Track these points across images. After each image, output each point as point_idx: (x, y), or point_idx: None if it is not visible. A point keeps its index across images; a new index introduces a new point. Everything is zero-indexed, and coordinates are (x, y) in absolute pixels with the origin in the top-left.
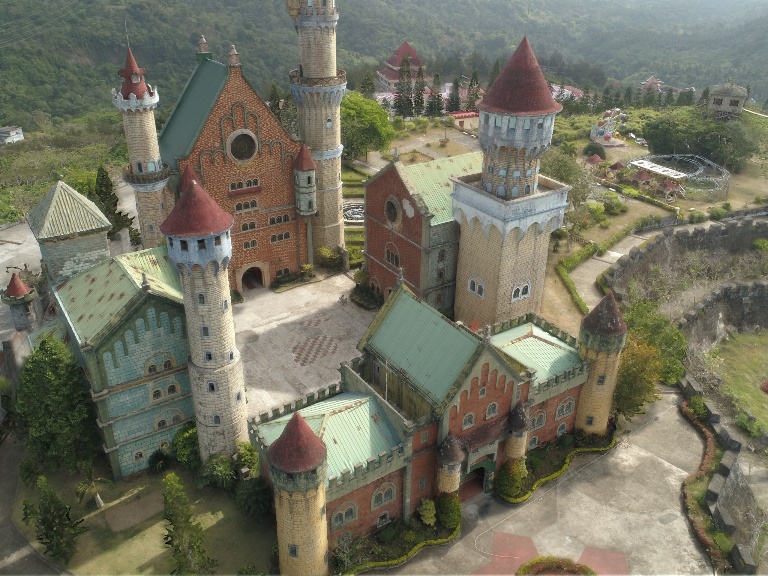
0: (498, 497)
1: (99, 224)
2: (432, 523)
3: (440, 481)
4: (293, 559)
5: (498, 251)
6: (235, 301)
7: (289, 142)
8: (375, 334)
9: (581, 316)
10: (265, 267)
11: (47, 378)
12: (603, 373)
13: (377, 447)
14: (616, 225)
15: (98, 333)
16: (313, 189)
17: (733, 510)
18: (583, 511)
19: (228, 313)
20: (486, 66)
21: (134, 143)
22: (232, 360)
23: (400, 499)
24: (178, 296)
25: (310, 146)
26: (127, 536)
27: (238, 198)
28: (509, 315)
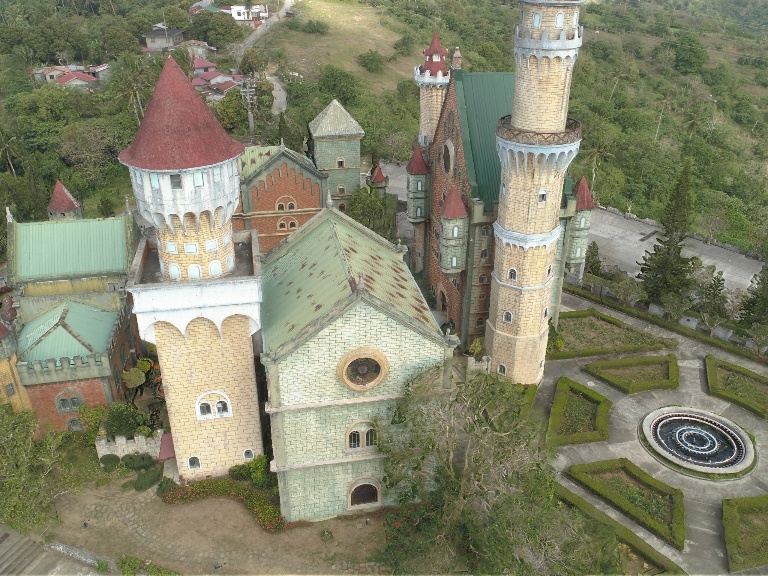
0: None
1: None
2: None
3: None
4: None
5: None
6: None
7: None
8: None
9: (194, 575)
10: None
11: None
12: None
13: None
14: None
15: None
16: None
17: None
18: None
19: None
20: None
21: None
22: None
23: None
24: None
25: None
26: None
27: None
28: None
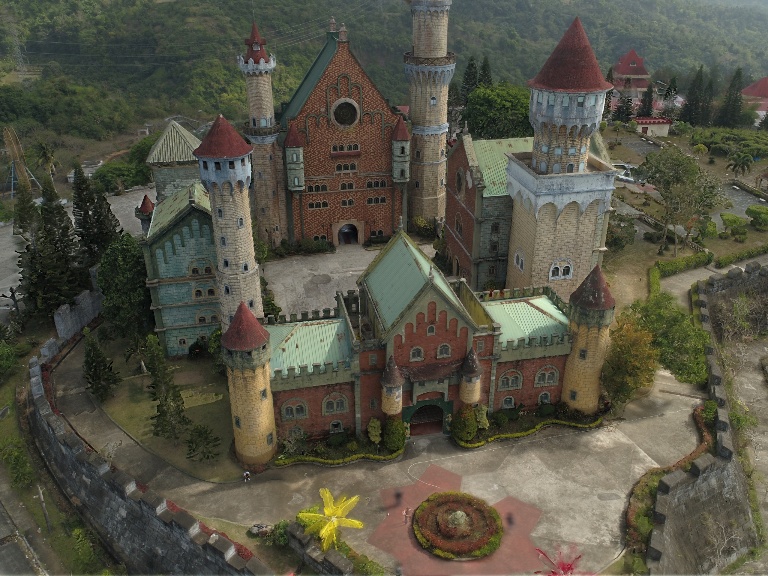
0: (453, 439)
1: (194, 157)
2: (377, 441)
3: (382, 402)
4: (238, 430)
5: (534, 225)
6: (328, 251)
7: (390, 114)
8: (372, 272)
9: None
10: (360, 226)
11: (118, 262)
12: (584, 347)
13: (331, 359)
14: (756, 241)
15: (154, 233)
16: (406, 159)
17: (702, 515)
18: (526, 469)
19: (244, 230)
20: (687, 73)
21: (251, 101)
22: (246, 271)
23: (353, 413)
24: None
25: (415, 121)
26: (151, 395)
27: (339, 159)
28: None
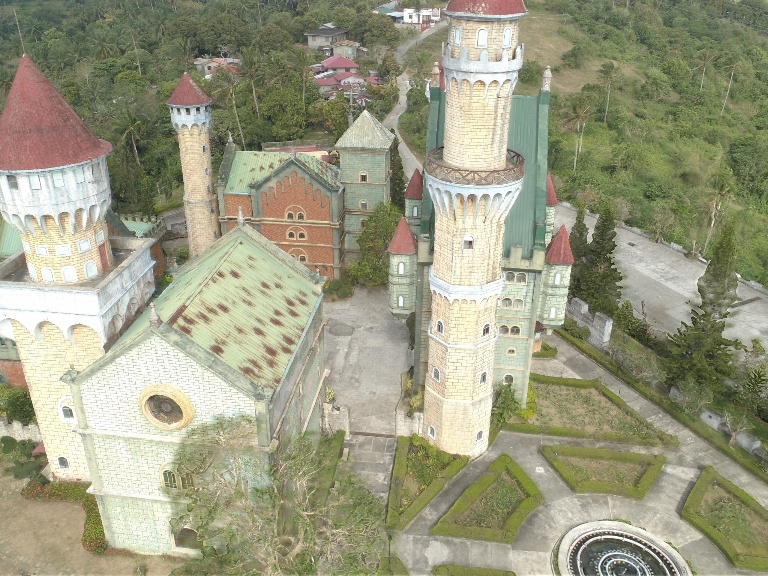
0: None
1: None
2: None
3: None
4: None
5: None
6: None
7: None
8: None
9: None
10: None
11: None
12: None
13: None
14: None
15: None
16: None
17: None
18: None
19: None
20: None
21: None
22: None
23: None
24: (254, 178)
25: None
26: None
27: None
28: None
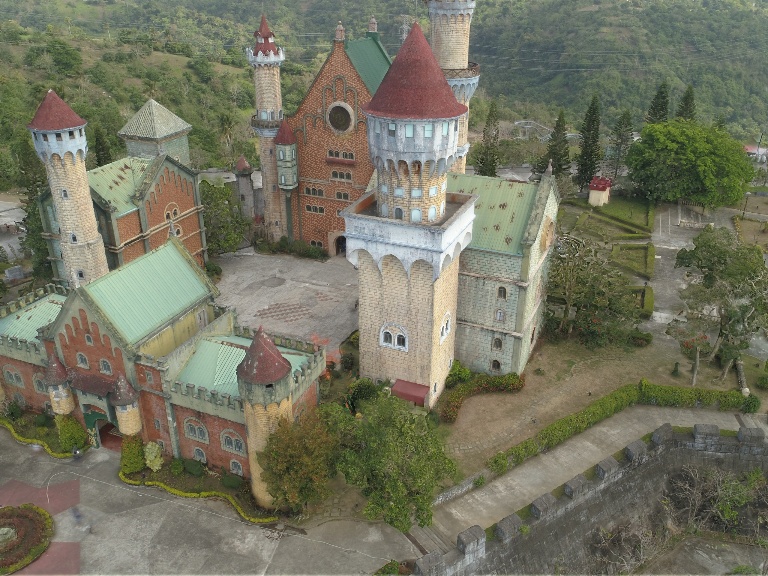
0: None
1: (152, 135)
2: None
3: None
4: None
5: None
6: (319, 259)
7: None
8: None
9: (532, 436)
10: None
11: None
12: None
13: None
14: None
15: None
16: None
17: None
18: (134, 528)
19: (70, 202)
20: None
21: None
22: (75, 242)
23: None
24: (122, 194)
25: None
26: None
27: (335, 166)
28: (381, 360)
